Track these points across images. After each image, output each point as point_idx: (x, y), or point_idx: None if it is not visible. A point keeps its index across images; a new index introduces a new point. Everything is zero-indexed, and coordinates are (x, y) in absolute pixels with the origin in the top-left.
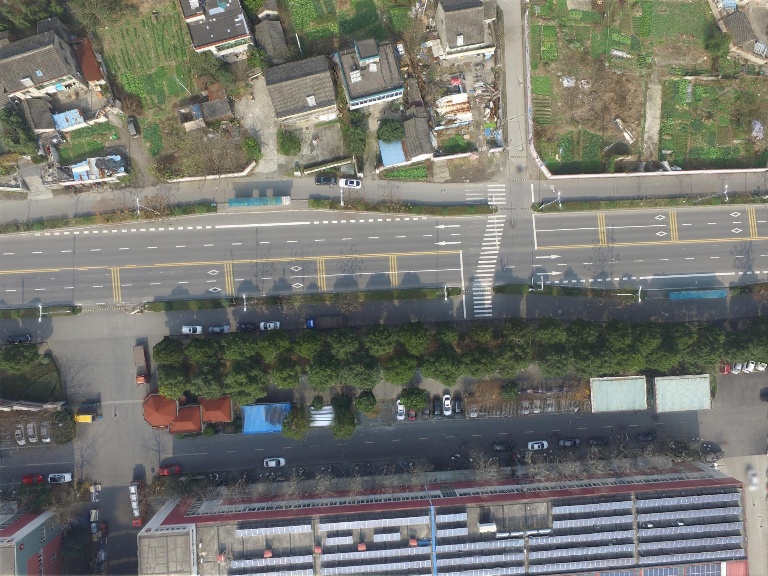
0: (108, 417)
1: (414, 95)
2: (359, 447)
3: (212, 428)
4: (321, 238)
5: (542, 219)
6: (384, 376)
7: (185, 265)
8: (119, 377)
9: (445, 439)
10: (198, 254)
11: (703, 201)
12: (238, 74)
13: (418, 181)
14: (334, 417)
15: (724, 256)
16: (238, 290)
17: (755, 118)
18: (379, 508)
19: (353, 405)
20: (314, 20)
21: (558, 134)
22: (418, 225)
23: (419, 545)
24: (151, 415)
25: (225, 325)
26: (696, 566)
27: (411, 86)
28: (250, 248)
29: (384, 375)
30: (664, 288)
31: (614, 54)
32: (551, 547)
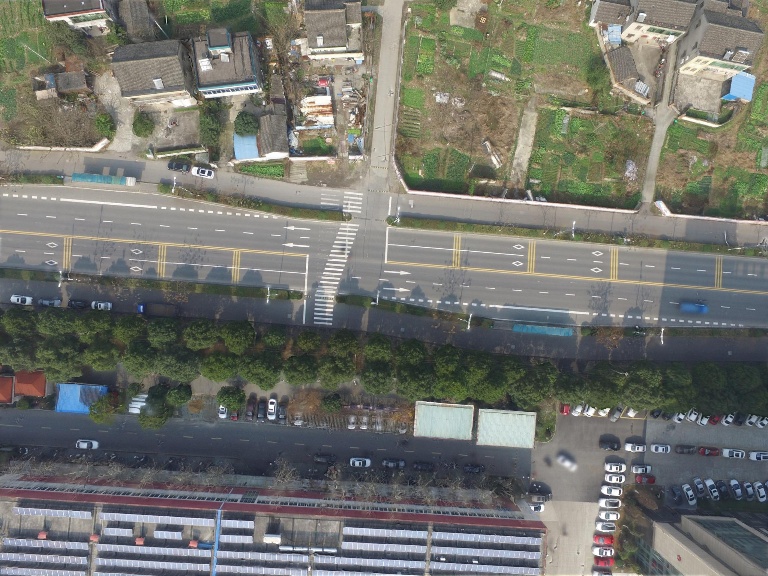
0: None
1: (277, 91)
2: (177, 440)
3: (27, 401)
4: (166, 224)
5: (396, 233)
6: (201, 371)
7: (24, 234)
8: None
9: (266, 444)
10: (39, 224)
11: (564, 236)
12: (94, 48)
13: (274, 179)
14: (141, 406)
15: (580, 294)
16: (75, 266)
17: (631, 158)
18: (165, 504)
19: None
20: (185, 4)
21: (424, 149)
22: (268, 223)
23: (199, 547)
24: None
25: (56, 299)
26: None
27: (275, 82)
28: (93, 225)
29: (201, 370)
30: (513, 319)
31: (493, 75)
32: (338, 568)
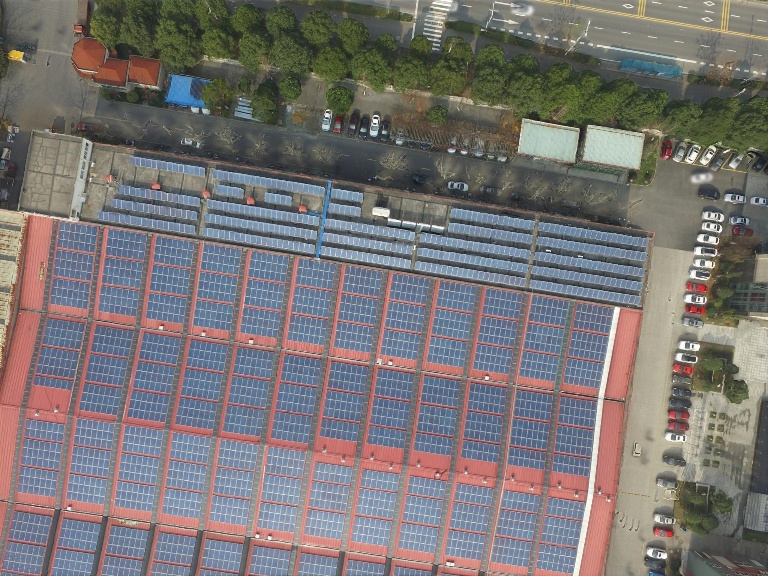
0: (41, 64)
1: None
2: (279, 149)
3: (138, 94)
4: None
5: None
6: (314, 65)
7: None
8: (60, 28)
9: (366, 161)
10: None
11: None
12: None
13: None
14: (255, 90)
15: (689, 42)
16: None
17: None
18: None
19: (281, 106)
20: None
21: None
22: None
23: (308, 213)
24: (78, 54)
25: None
26: (588, 305)
27: None
28: None
29: (314, 64)
30: (620, 61)
31: None
32: (442, 250)
